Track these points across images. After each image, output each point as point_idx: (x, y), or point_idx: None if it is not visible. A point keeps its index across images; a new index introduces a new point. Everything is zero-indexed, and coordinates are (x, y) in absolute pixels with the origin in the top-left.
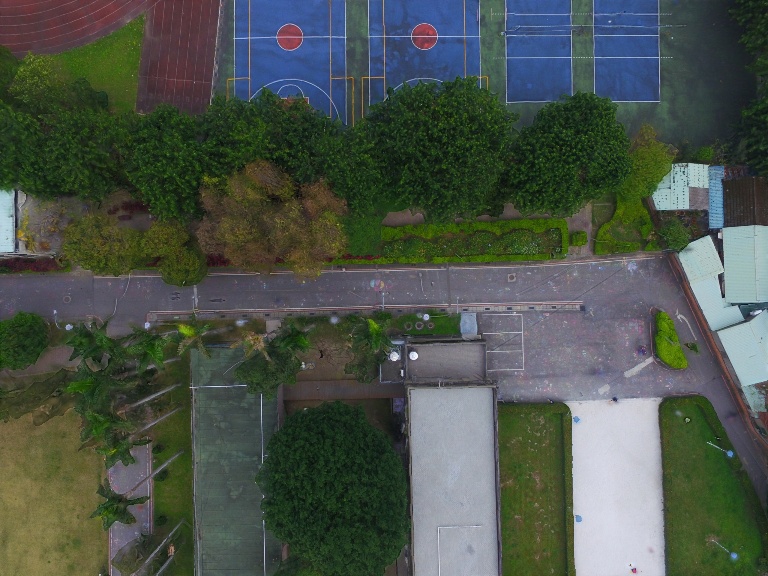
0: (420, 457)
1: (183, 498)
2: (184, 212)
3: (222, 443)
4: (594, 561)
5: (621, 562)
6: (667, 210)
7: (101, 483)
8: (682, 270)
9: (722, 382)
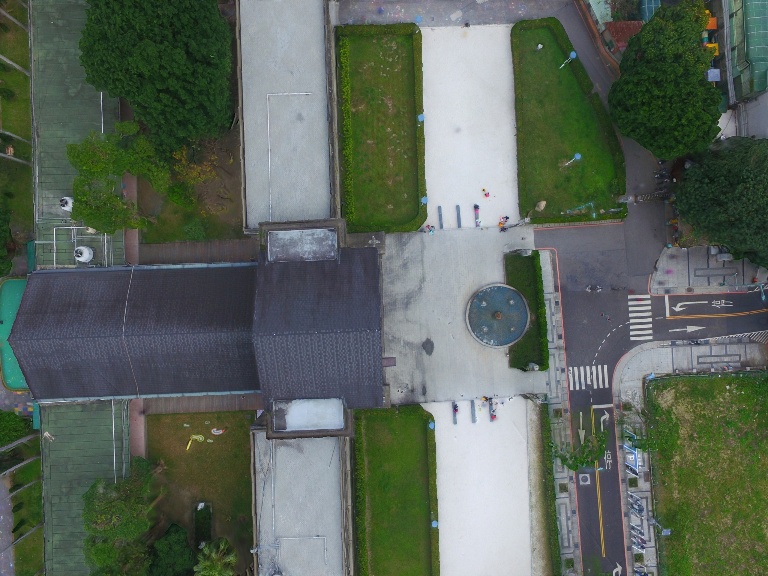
0: (249, 26)
1: None
2: None
3: (60, 41)
4: (447, 186)
5: (474, 187)
6: None
7: None
8: None
9: (575, 9)
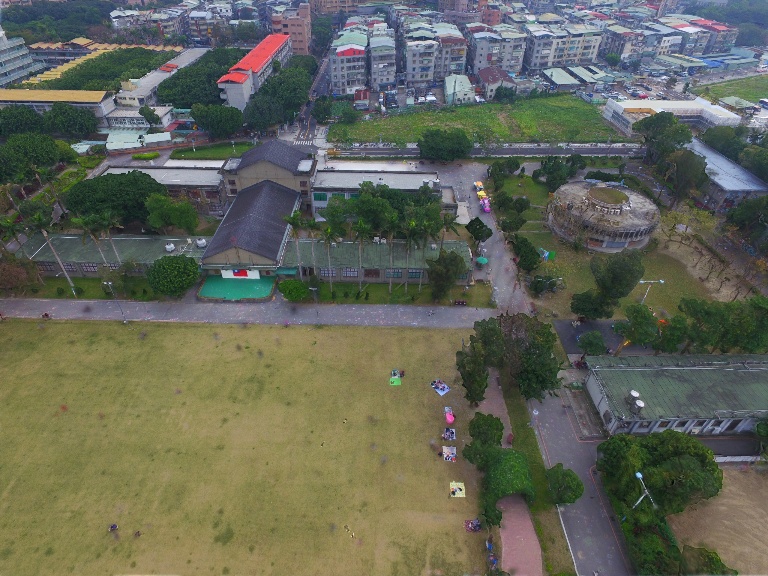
0: None
1: None
2: None
3: (73, 252)
4: None
5: None
6: (90, 154)
7: None
8: (117, 151)
9: (173, 149)
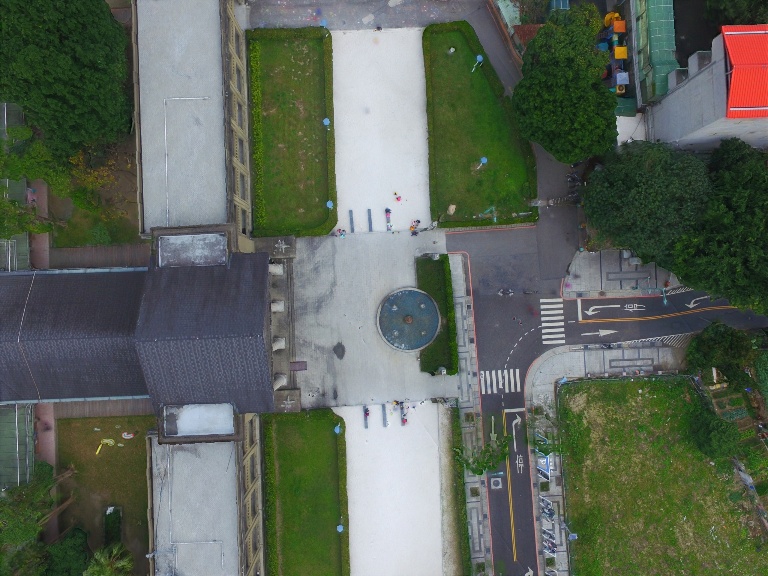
0: (147, 30)
1: None
2: None
3: None
4: (359, 190)
5: (386, 191)
6: None
7: None
8: None
9: (487, 12)
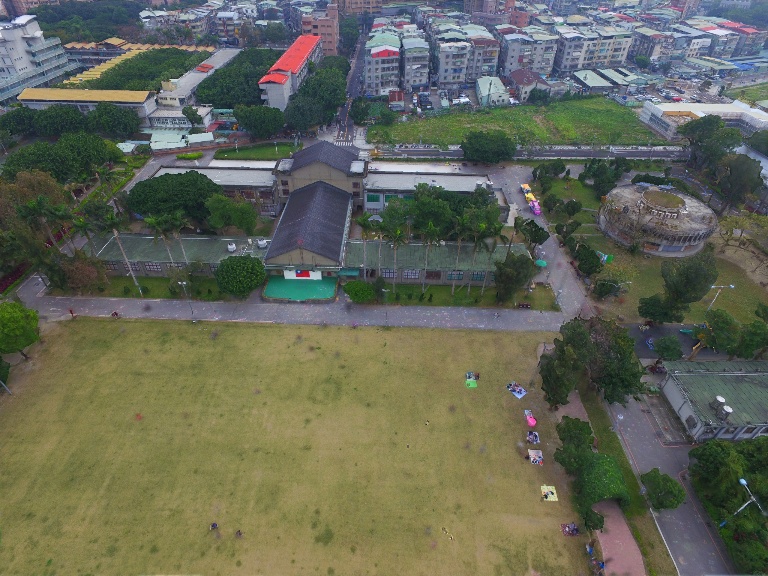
0: None
1: (167, 286)
2: None
3: (136, 251)
4: None
5: None
6: None
7: None
8: (162, 151)
9: (215, 149)
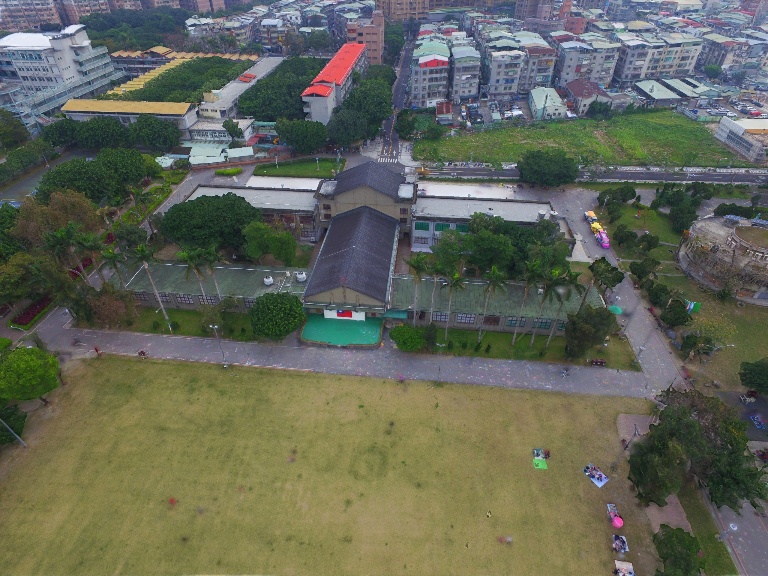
0: None
1: (199, 321)
2: (16, 249)
3: (167, 281)
4: None
5: None
6: None
7: (159, 363)
8: (200, 166)
9: (255, 164)
